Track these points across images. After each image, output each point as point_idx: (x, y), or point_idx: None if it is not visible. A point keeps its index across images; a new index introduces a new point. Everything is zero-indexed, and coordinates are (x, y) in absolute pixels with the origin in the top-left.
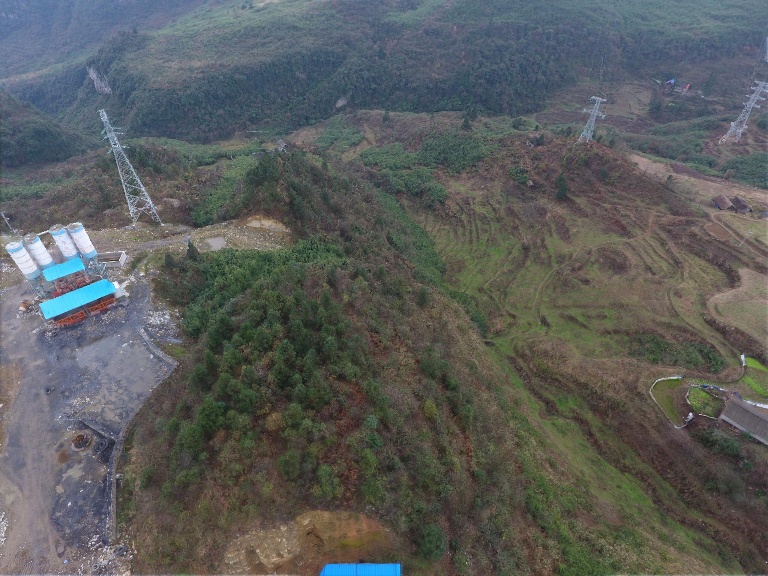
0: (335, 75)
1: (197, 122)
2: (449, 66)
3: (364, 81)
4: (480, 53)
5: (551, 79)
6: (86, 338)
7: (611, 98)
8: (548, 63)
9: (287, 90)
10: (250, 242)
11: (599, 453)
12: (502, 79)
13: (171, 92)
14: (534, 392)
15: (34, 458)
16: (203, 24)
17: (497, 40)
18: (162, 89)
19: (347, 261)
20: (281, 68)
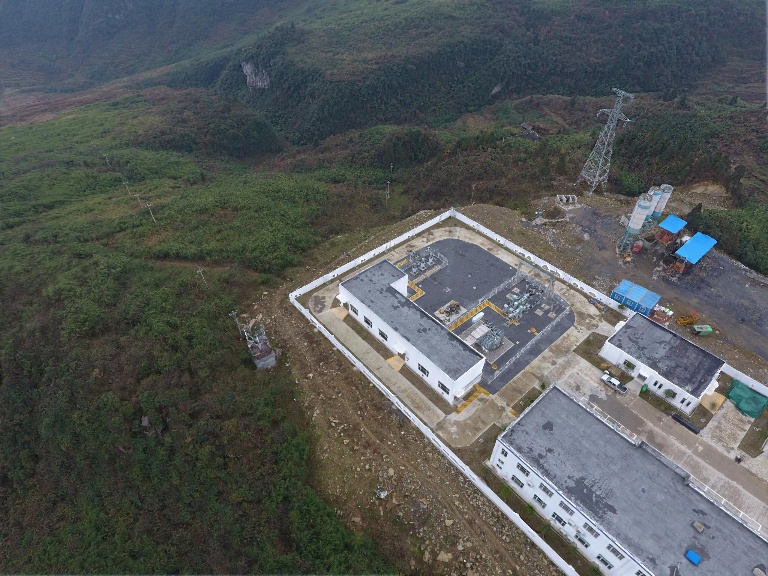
0: (494, 62)
1: (374, 112)
2: (607, 50)
3: (521, 67)
4: (638, 36)
5: (704, 60)
6: (708, 281)
7: (762, 77)
8: (701, 44)
9: (448, 78)
10: (707, 205)
11: None
12: (660, 61)
13: (351, 83)
14: None
15: None
16: (350, 17)
17: (653, 23)
18: (343, 81)
19: None
20: (445, 57)
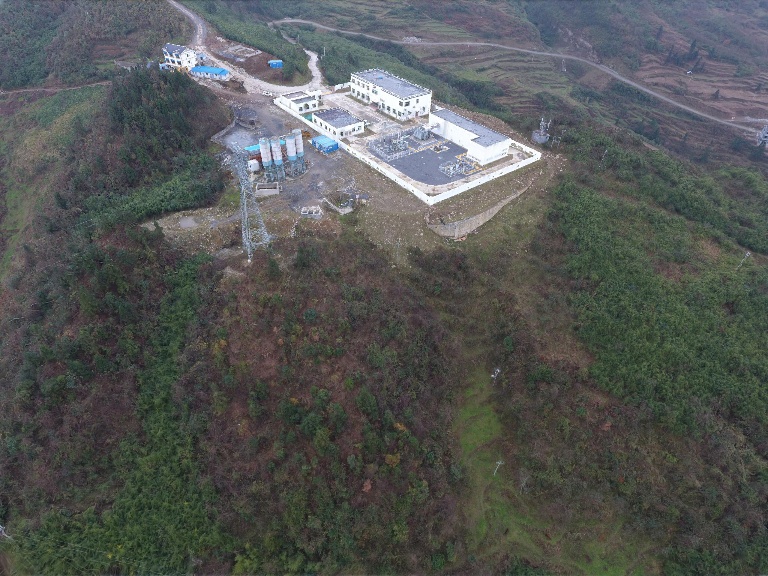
0: None
1: None
2: None
3: None
4: None
5: None
6: None
7: None
8: None
9: None
10: None
11: (6, 212)
12: None
13: None
14: (4, 248)
15: None
16: None
17: None
18: None
19: (79, 209)
20: None
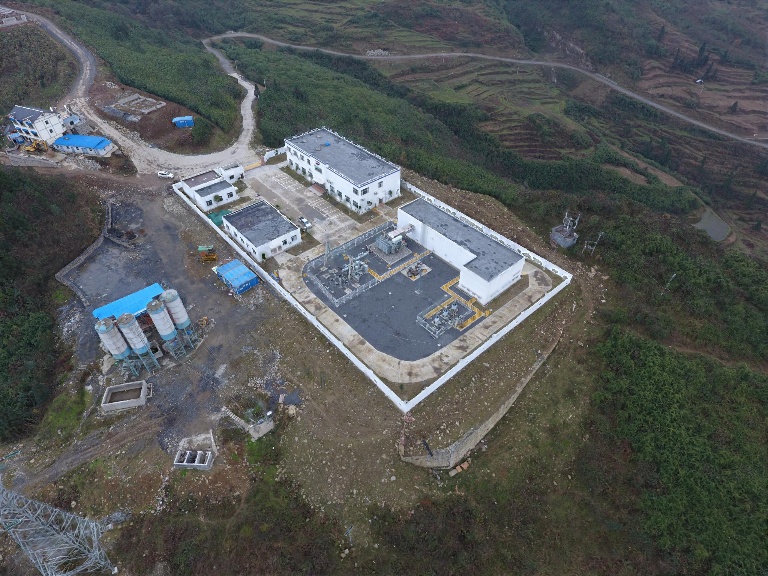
0: None
1: None
2: None
3: None
4: None
5: None
6: None
7: None
8: None
9: None
10: None
11: None
12: None
13: None
14: None
15: (159, 230)
16: None
17: None
18: None
19: None
20: None
